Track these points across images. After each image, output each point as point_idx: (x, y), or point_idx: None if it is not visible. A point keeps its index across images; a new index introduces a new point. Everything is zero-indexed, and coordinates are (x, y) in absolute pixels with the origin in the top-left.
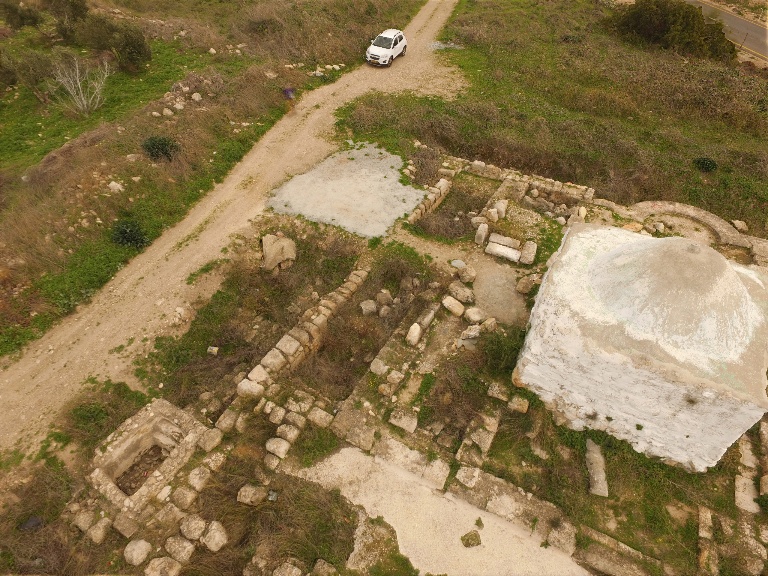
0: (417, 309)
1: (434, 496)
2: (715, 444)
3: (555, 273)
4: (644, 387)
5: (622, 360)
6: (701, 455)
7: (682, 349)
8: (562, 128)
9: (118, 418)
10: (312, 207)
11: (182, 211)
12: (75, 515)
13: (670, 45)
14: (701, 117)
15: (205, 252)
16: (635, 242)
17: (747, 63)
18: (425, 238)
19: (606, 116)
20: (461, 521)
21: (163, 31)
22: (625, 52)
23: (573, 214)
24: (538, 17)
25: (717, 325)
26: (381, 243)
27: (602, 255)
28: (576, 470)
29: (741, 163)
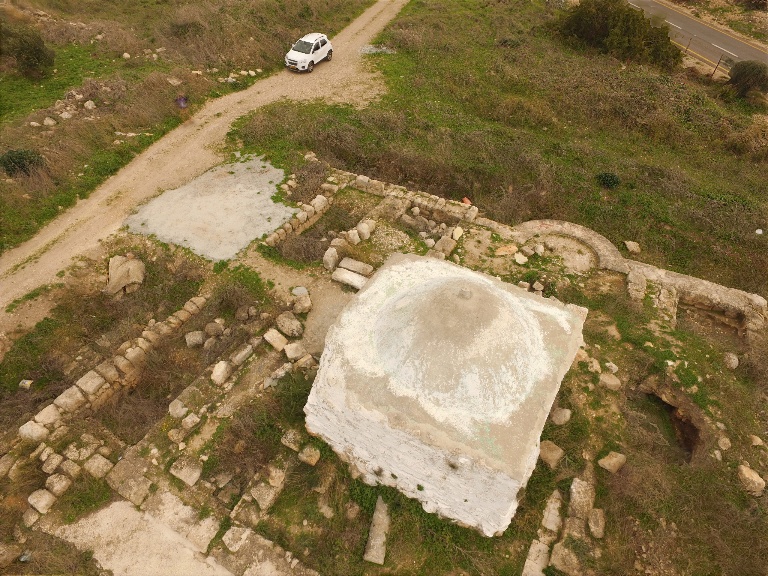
0: (237, 343)
1: (194, 560)
2: (493, 510)
3: (346, 313)
4: (408, 447)
5: (379, 418)
6: (487, 519)
7: (443, 407)
8: (467, 139)
9: None
10: (169, 226)
11: (32, 230)
12: None
13: (609, 50)
14: (620, 128)
15: (39, 276)
16: None
17: (690, 69)
18: (276, 262)
19: (520, 126)
20: None
21: (81, 34)
22: (563, 57)
23: (445, 235)
24: (483, 20)
25: (480, 381)
26: (227, 267)
27: (401, 293)
28: (357, 532)
29: (646, 178)
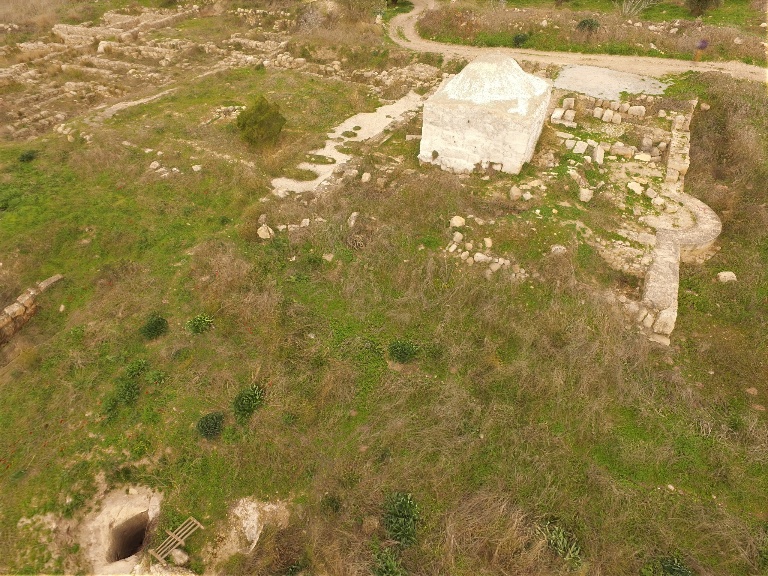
0: None
1: None
2: None
3: None
4: None
5: None
6: None
7: None
8: None
9: (429, 62)
10: None
11: (549, 49)
12: (396, 67)
13: None
14: None
15: None
16: None
17: None
18: None
19: None
20: (395, 115)
21: None
22: None
23: None
24: None
25: None
26: None
27: None
28: None
29: None
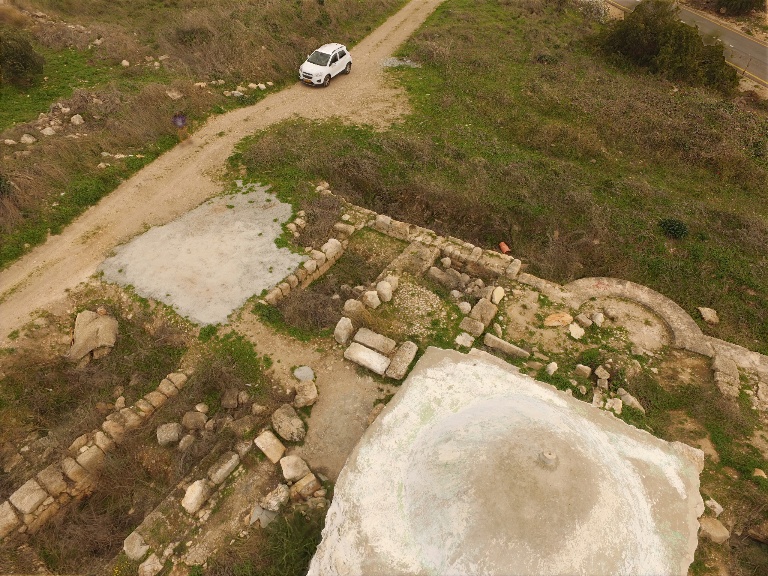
0: (220, 448)
1: None
2: None
3: (364, 447)
4: None
5: None
6: None
7: None
8: (504, 172)
9: None
10: (150, 275)
11: None
12: None
13: (658, 70)
14: (680, 162)
15: None
16: (484, 410)
17: (749, 93)
18: (276, 328)
19: (564, 157)
20: None
21: (79, 39)
22: (606, 76)
23: (484, 297)
24: (515, 32)
25: None
26: (216, 334)
27: (442, 419)
28: None
29: (719, 228)
